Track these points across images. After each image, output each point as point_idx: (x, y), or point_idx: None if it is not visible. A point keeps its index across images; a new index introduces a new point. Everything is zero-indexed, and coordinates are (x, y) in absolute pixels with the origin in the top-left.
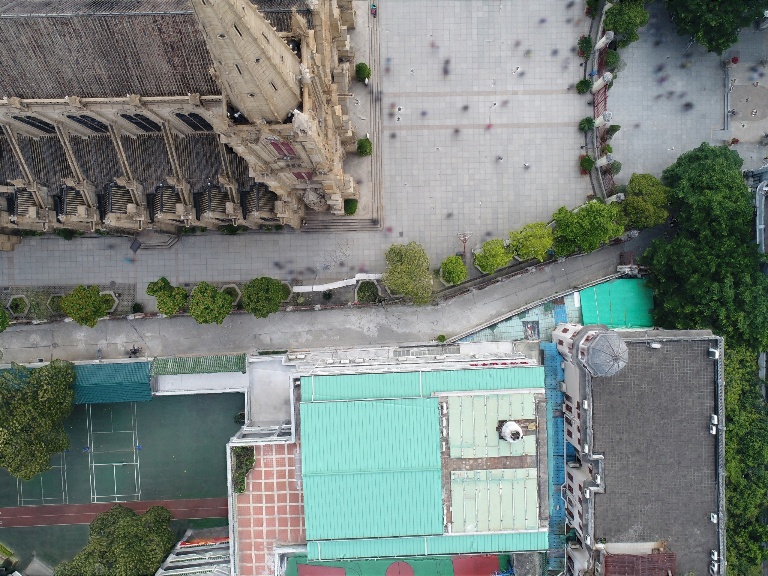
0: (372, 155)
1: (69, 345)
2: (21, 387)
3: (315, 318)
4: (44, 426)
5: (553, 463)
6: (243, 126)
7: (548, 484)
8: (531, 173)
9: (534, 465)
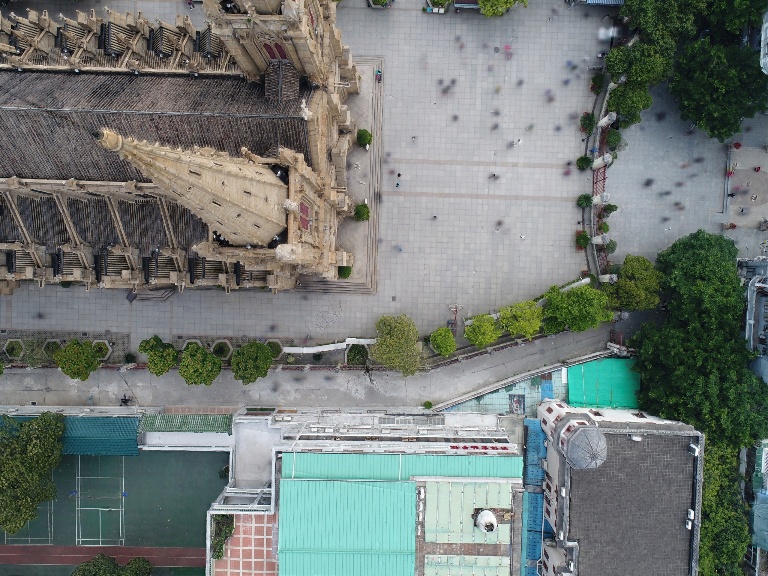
0: (369, 220)
1: (62, 390)
2: (10, 442)
3: (304, 377)
4: (31, 481)
5: (530, 538)
6: (228, 248)
7: (520, 573)
8: (527, 245)
9: (507, 553)
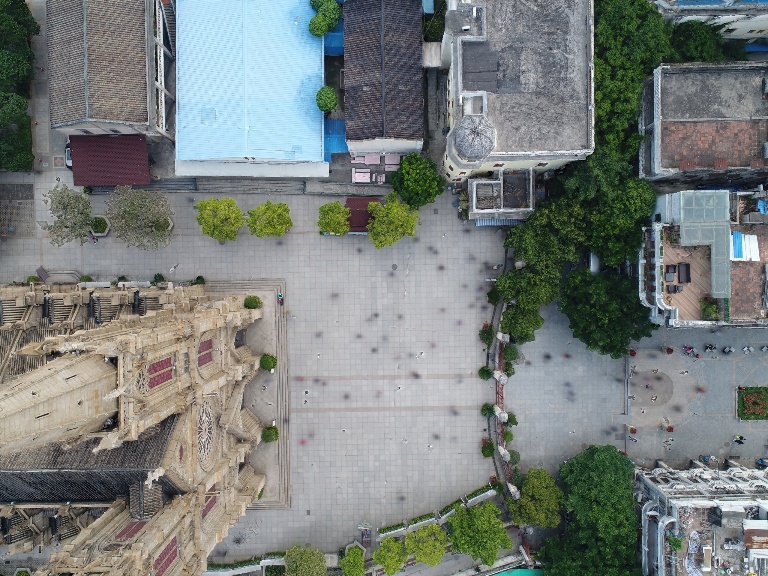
0: (279, 439)
1: None
2: None
3: None
4: None
5: None
6: None
7: None
8: (435, 454)
9: None
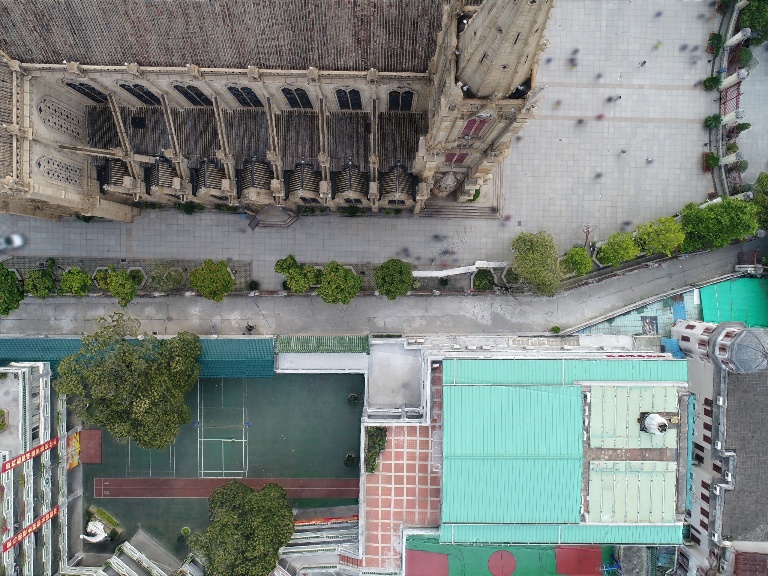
0: None
1: (184, 319)
2: (156, 357)
3: (430, 304)
4: (177, 397)
5: None
6: (470, 100)
7: (686, 478)
8: (653, 168)
9: (673, 458)
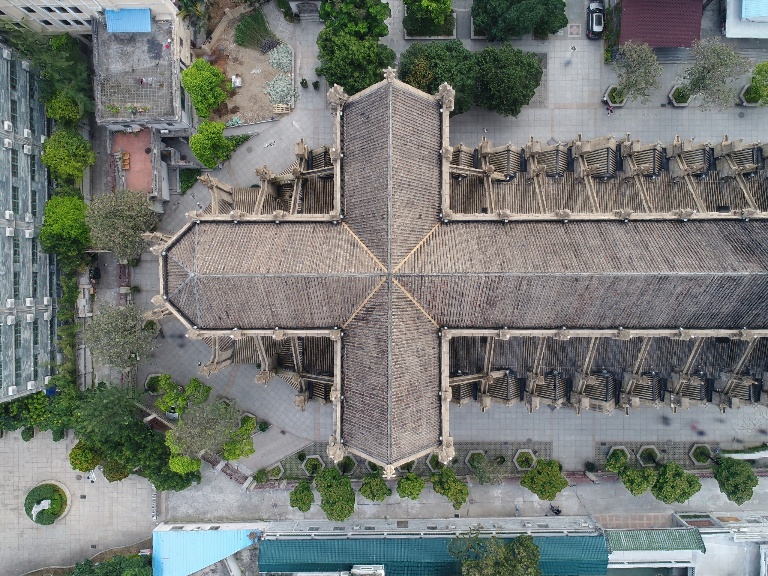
0: None
1: (486, 502)
2: (516, 574)
3: None
4: None
5: None
6: None
7: None
8: None
9: None
